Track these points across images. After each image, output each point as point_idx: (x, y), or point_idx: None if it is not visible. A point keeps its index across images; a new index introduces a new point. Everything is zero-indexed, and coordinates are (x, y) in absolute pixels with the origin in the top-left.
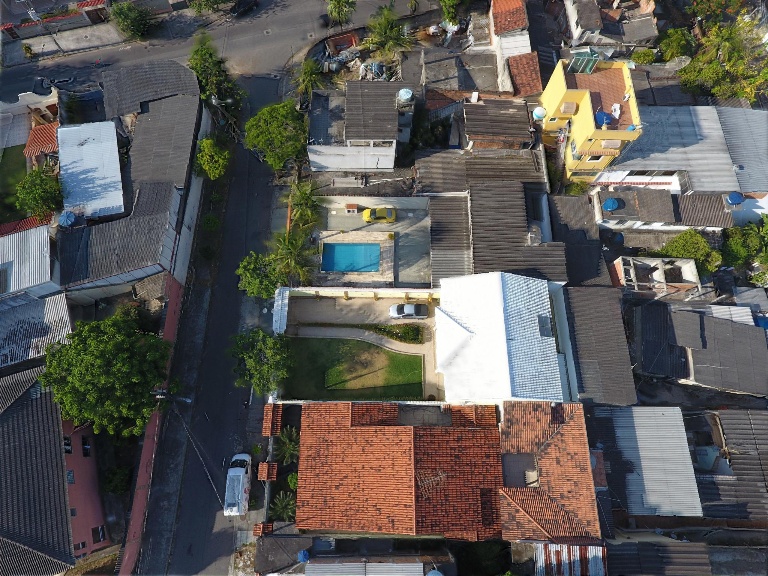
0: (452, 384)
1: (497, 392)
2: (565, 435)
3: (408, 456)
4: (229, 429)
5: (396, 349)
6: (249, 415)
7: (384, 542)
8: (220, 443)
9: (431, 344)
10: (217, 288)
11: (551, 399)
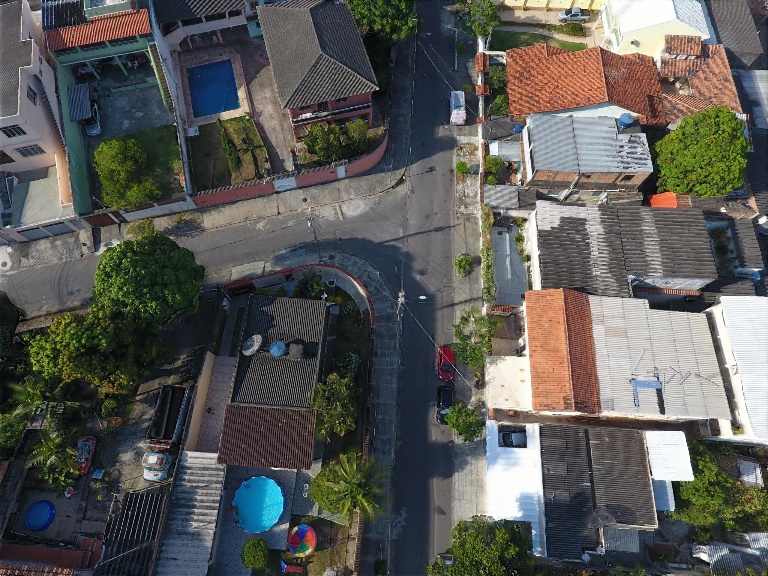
0: (626, 23)
1: (664, 19)
2: (710, 64)
3: (597, 62)
4: (442, 82)
5: (565, 40)
6: (456, 75)
7: None
8: (437, 89)
9: (592, 38)
10: (420, 5)
11: (702, 32)
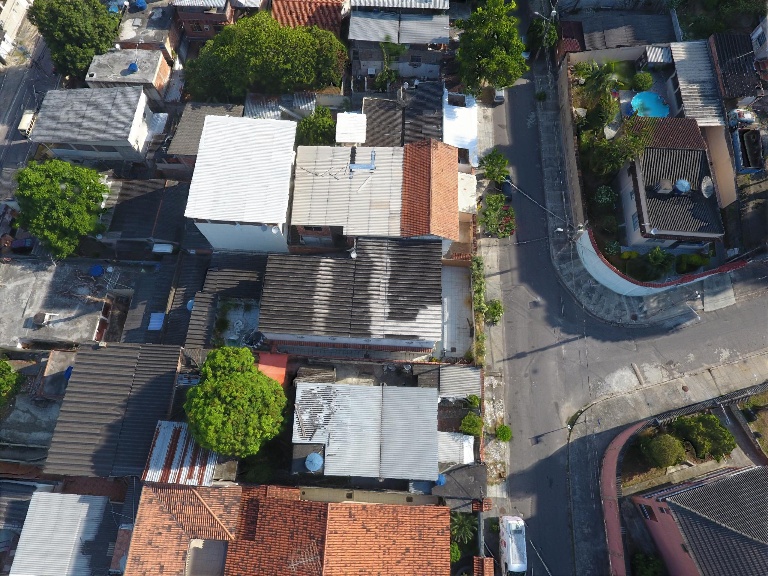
0: None
1: None
2: None
3: None
4: None
5: None
6: None
7: (360, 481)
8: None
9: None
10: None
11: None
